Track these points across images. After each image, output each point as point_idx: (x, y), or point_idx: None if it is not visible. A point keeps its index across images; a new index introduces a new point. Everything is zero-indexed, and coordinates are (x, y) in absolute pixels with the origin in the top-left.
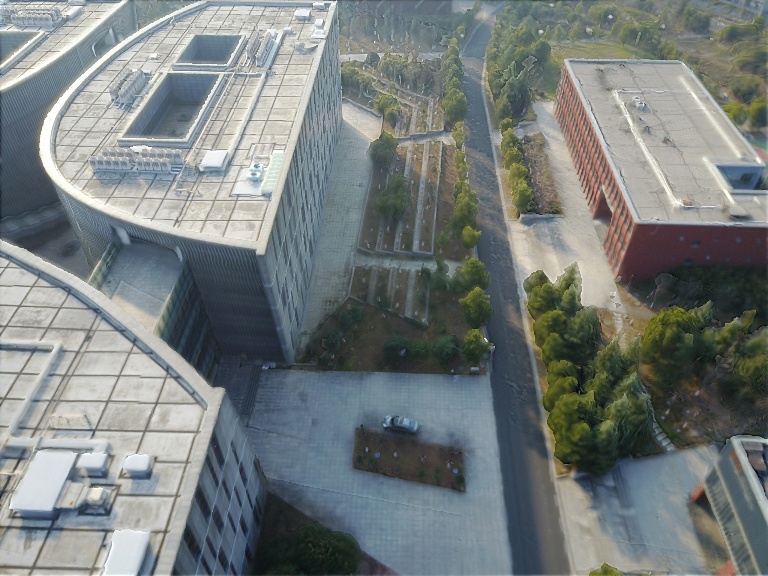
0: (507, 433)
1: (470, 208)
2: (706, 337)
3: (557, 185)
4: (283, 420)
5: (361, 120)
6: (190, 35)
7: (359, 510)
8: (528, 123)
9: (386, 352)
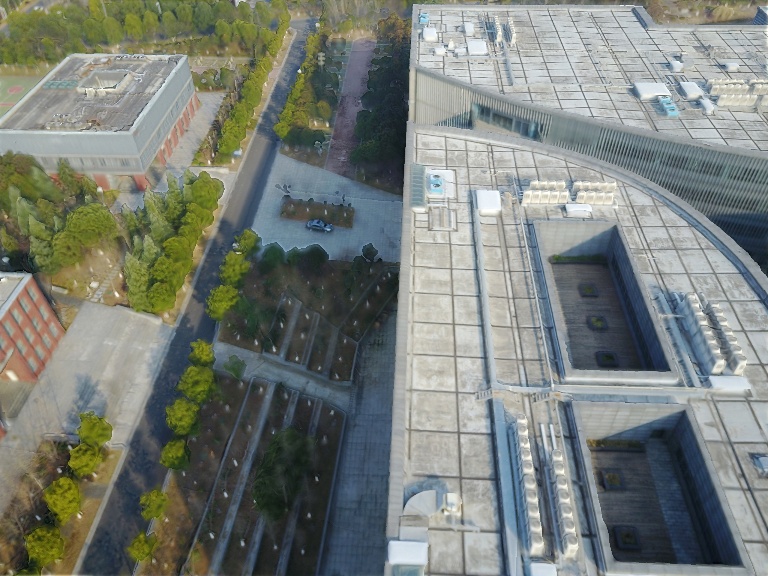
0: (245, 224)
1: None
2: None
3: None
4: None
5: None
6: None
7: (351, 192)
8: None
9: None
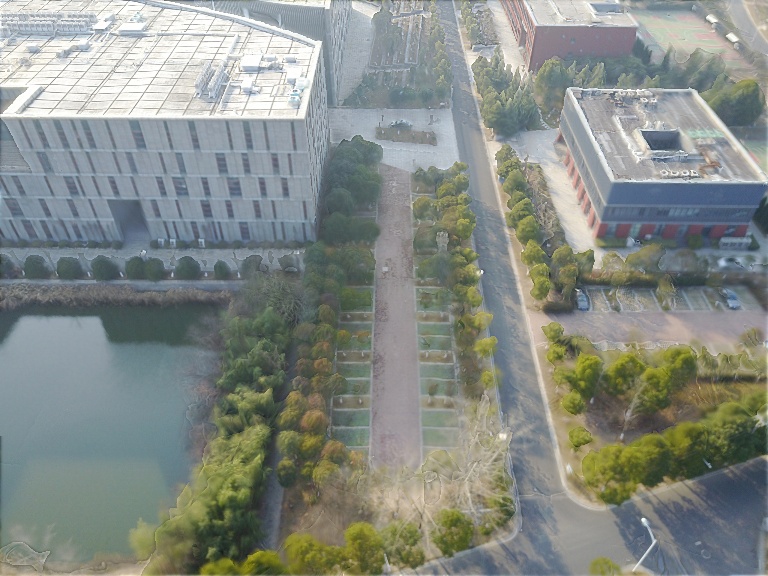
0: (460, 127)
1: (440, 33)
2: (570, 76)
3: (497, 33)
4: (335, 125)
5: (365, 9)
6: None
7: None
8: (481, 5)
9: (391, 94)
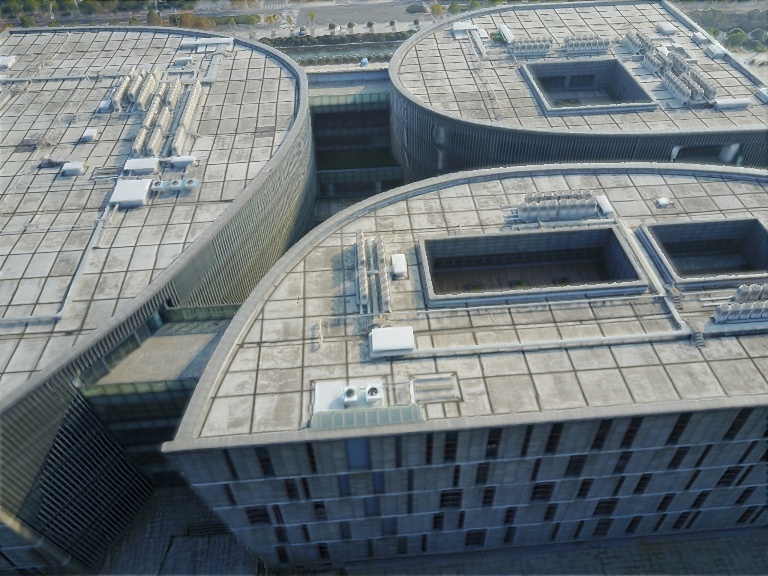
0: None
1: None
2: None
3: None
4: None
5: None
6: (763, 215)
7: None
8: None
9: None
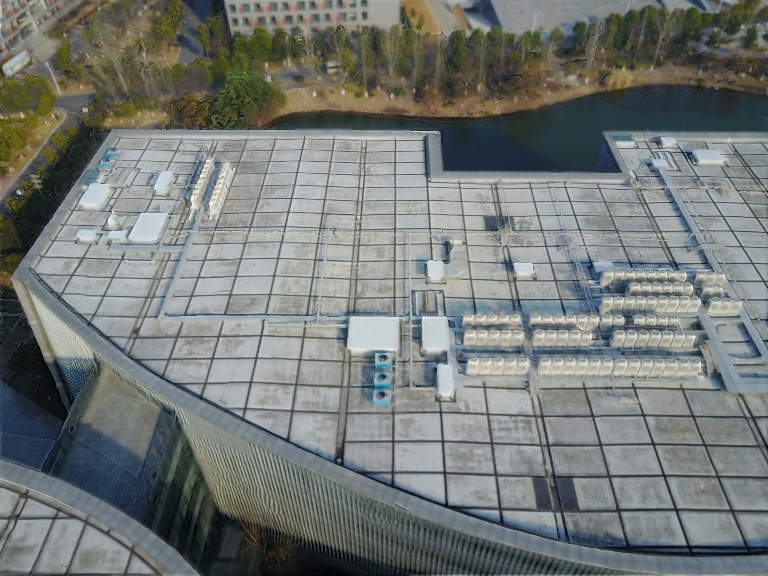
0: None
1: None
2: None
3: None
4: None
5: None
6: None
7: (4, 420)
8: None
9: None
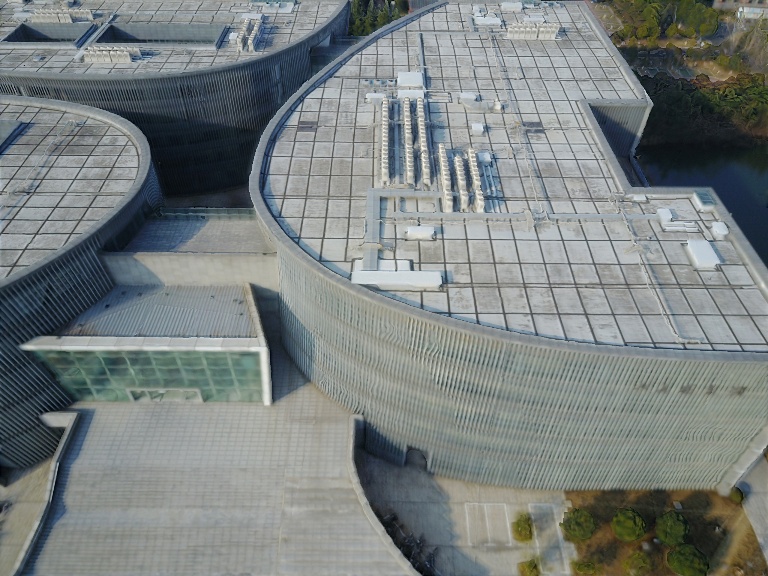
0: None
1: None
2: None
3: None
4: None
5: None
6: None
7: None
8: None
9: None
